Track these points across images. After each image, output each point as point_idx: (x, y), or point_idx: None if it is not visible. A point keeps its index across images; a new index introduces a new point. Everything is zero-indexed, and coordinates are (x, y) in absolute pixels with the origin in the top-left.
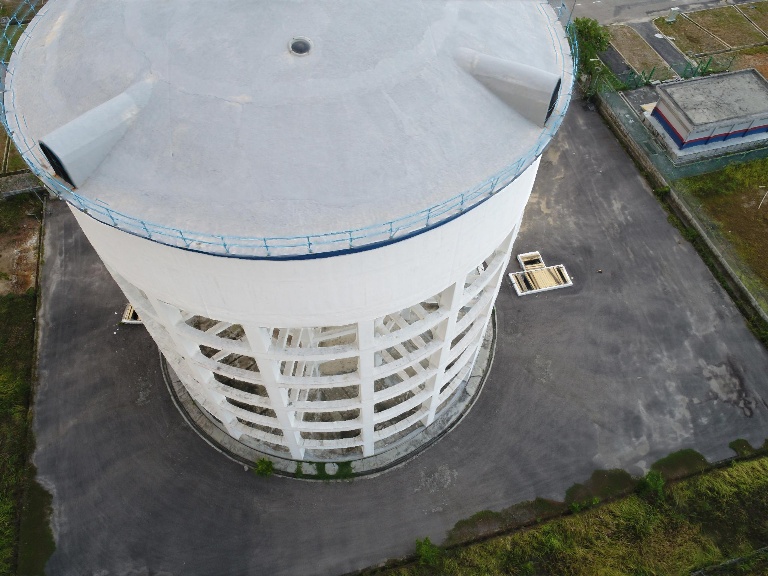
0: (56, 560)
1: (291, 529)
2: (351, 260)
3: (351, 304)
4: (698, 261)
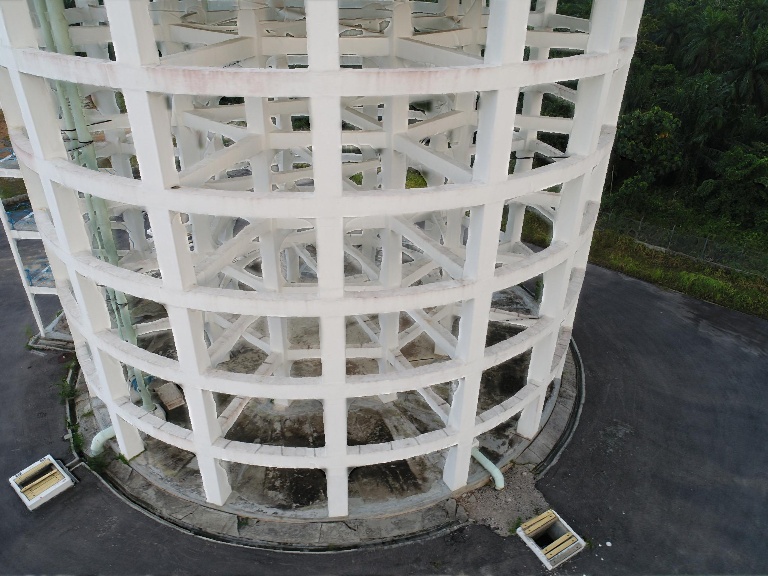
0: None
1: None
2: None
3: None
4: None
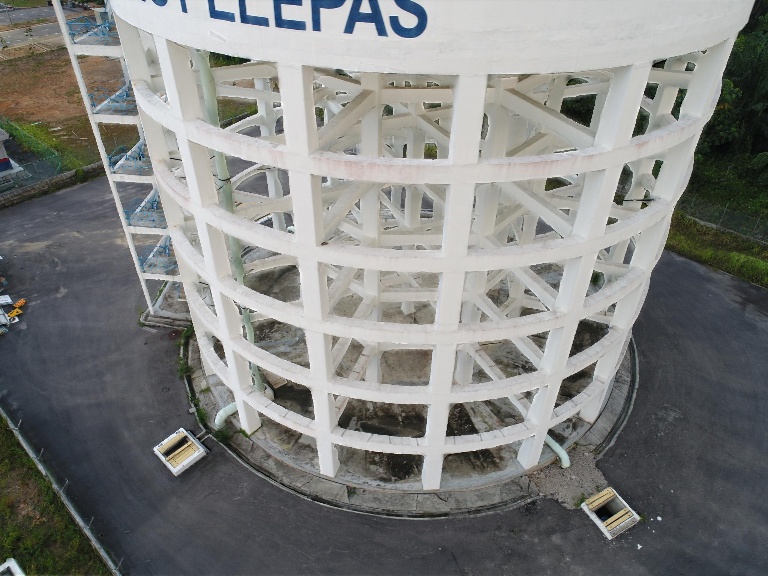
0: None
1: None
2: None
3: None
4: None
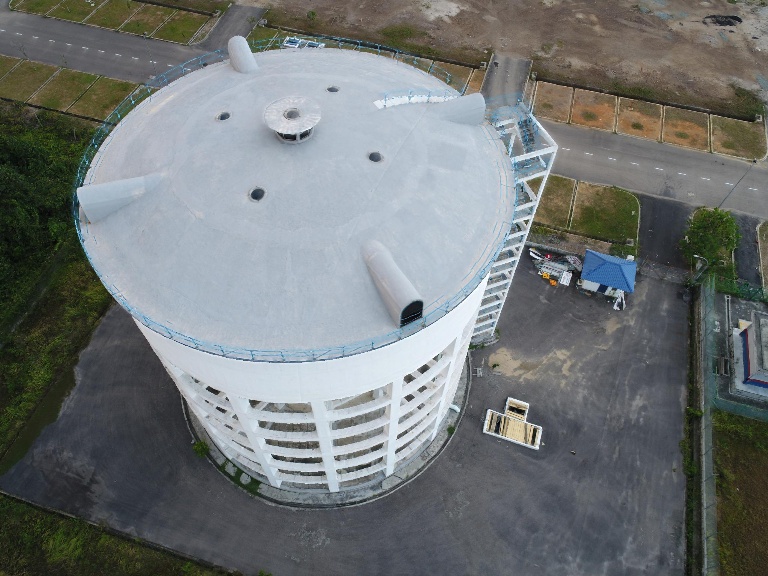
0: (51, 428)
1: (192, 504)
2: (208, 353)
3: (216, 379)
4: (680, 498)
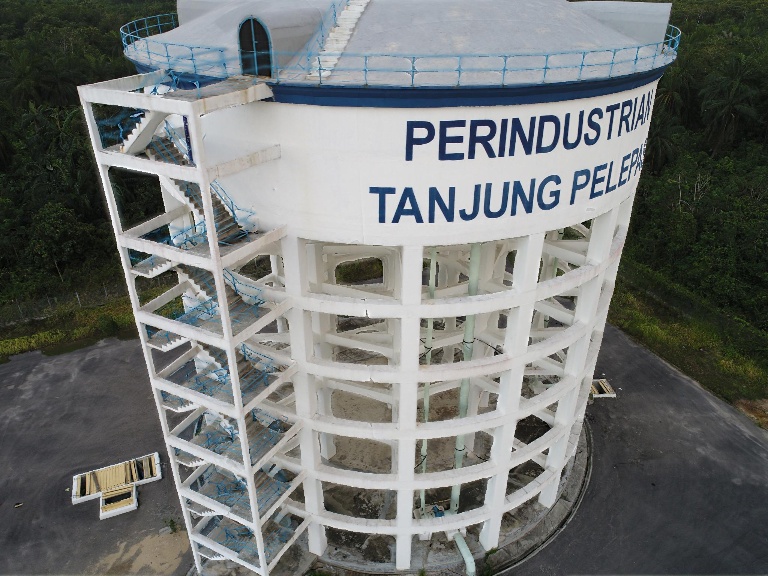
0: None
1: None
2: None
3: None
4: None
